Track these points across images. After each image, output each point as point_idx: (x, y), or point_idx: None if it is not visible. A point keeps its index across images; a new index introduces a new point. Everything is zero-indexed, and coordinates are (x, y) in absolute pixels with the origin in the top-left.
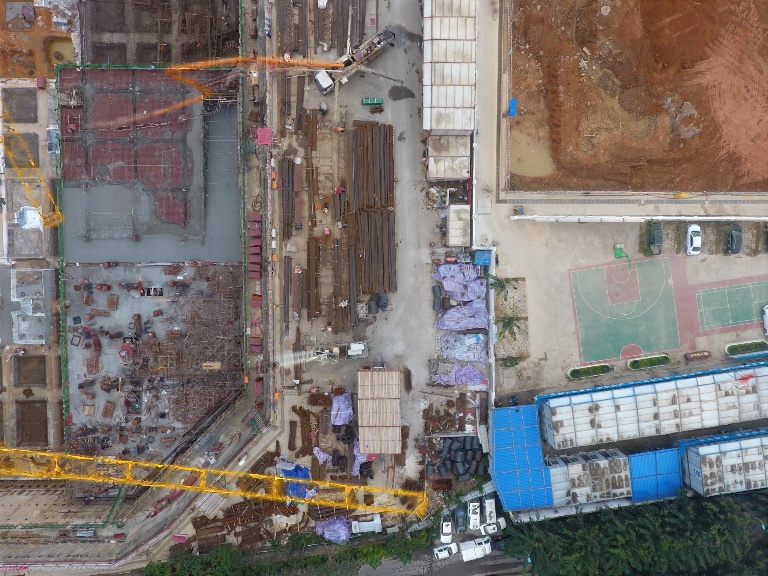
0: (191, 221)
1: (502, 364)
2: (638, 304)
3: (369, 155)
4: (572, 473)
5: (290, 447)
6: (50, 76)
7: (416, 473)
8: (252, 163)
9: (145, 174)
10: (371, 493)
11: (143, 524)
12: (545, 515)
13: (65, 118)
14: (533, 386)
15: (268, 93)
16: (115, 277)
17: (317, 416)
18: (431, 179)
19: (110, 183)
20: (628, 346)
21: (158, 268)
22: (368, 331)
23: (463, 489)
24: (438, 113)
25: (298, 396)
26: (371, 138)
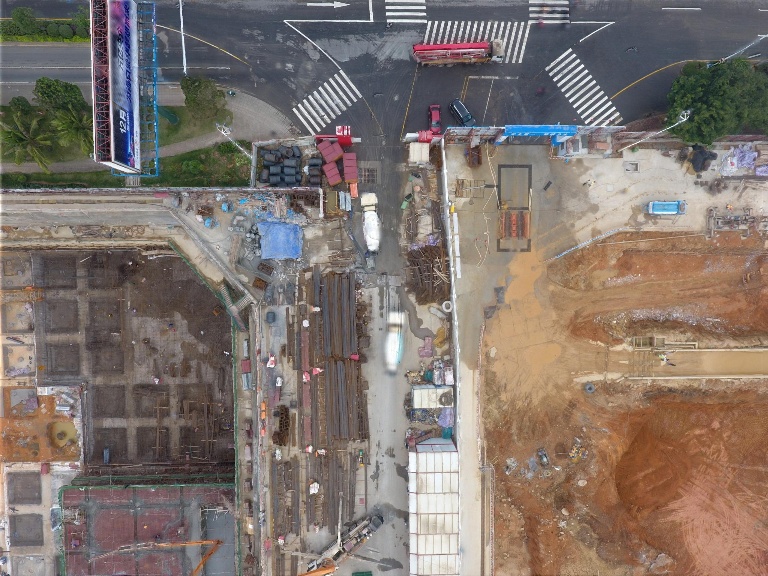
0: None
1: None
2: None
3: None
4: None
5: None
6: (53, 458)
7: None
8: None
9: None
10: None
11: None
12: None
13: (69, 534)
14: None
15: (263, 572)
16: None
17: None
18: None
19: None
20: None
21: None
22: None
23: None
24: None
25: None
26: None
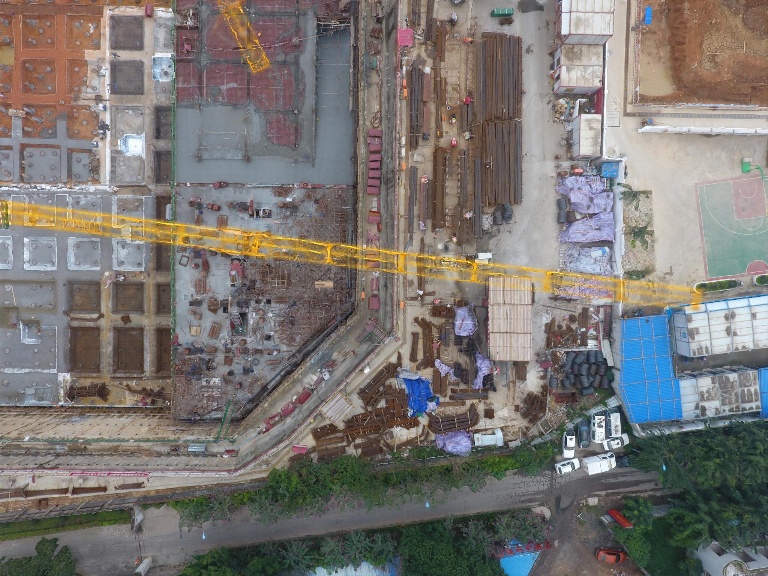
0: (301, 143)
1: (627, 278)
2: (765, 220)
3: (498, 66)
4: (701, 386)
5: (412, 358)
6: (157, 5)
7: (537, 388)
8: (372, 80)
9: (257, 96)
10: (491, 407)
11: (256, 439)
12: (671, 430)
13: (180, 39)
14: (658, 300)
15: (399, 3)
16: (225, 198)
17: (439, 328)
18: (561, 90)
19: (223, 104)
20: (754, 262)
21: (268, 190)
22: (492, 244)
23: (586, 403)
24: (577, 17)
25: (421, 307)
26: (501, 49)
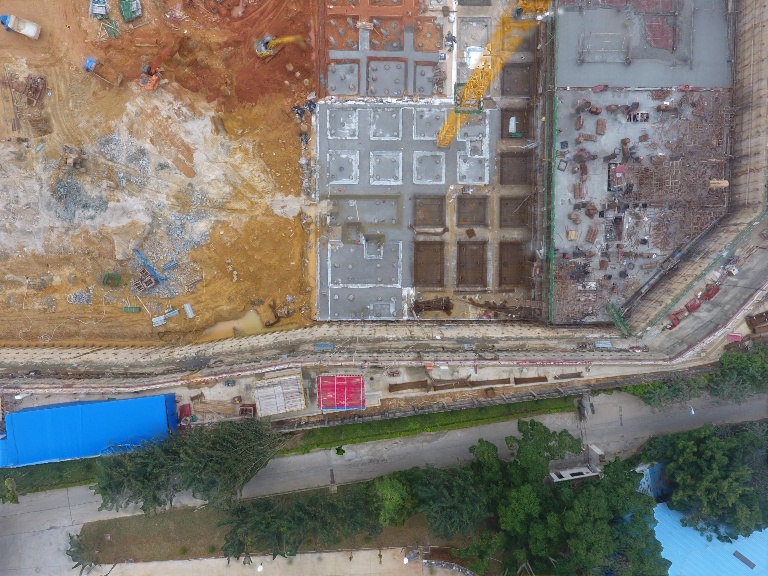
0: (680, 46)
1: None
2: None
3: None
4: None
5: None
6: None
7: None
8: None
9: None
10: None
11: (667, 334)
12: None
13: None
14: None
15: None
16: (603, 102)
17: None
18: None
19: (603, 7)
20: None
21: (645, 93)
22: None
23: None
24: None
25: None
26: None
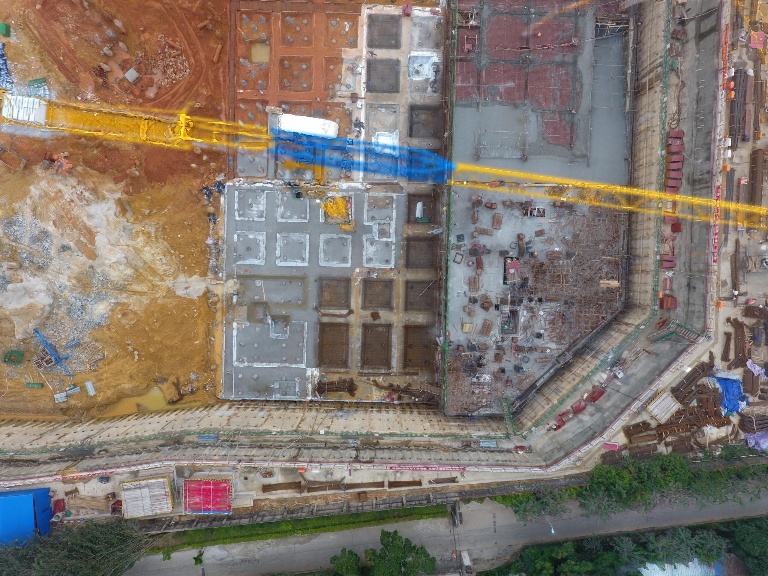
0: (577, 143)
1: None
2: None
3: None
4: None
5: (726, 358)
6: (413, 4)
7: None
8: (671, 81)
9: (534, 96)
10: None
11: (550, 436)
12: None
13: (461, 38)
14: None
15: None
16: (500, 196)
17: (752, 328)
18: None
19: (501, 103)
20: None
21: (542, 189)
22: None
23: None
24: None
25: (733, 308)
26: None
